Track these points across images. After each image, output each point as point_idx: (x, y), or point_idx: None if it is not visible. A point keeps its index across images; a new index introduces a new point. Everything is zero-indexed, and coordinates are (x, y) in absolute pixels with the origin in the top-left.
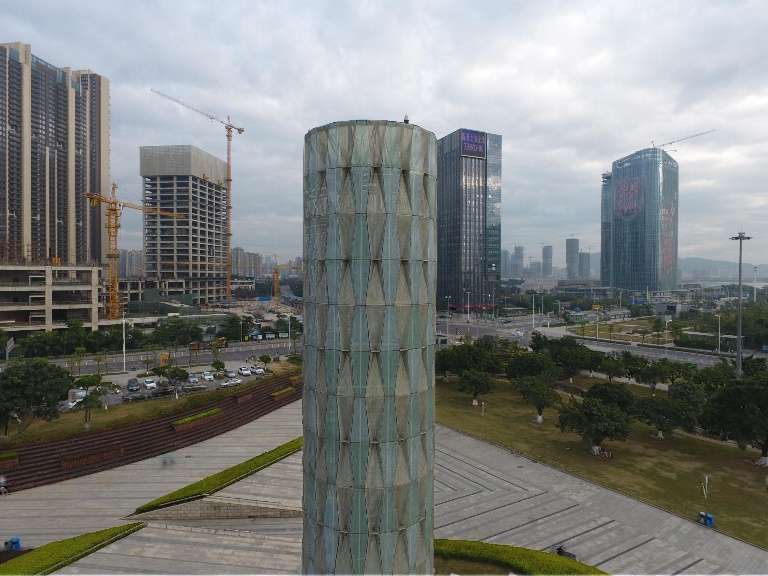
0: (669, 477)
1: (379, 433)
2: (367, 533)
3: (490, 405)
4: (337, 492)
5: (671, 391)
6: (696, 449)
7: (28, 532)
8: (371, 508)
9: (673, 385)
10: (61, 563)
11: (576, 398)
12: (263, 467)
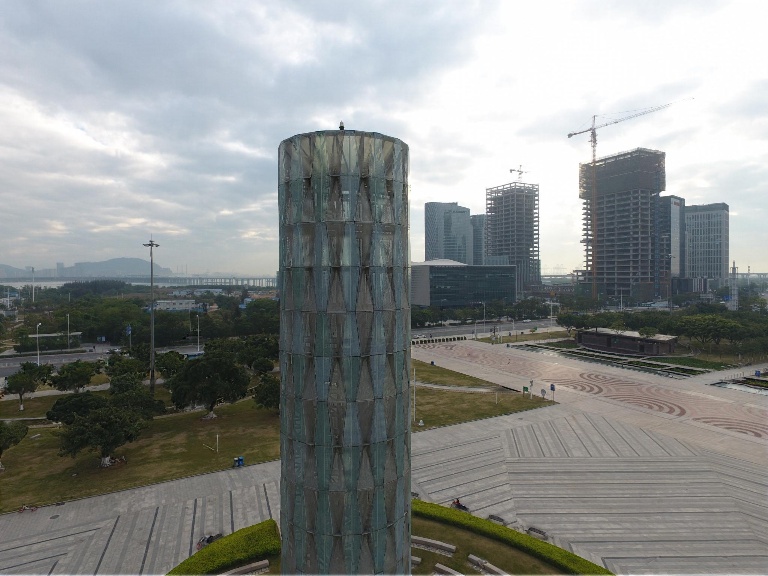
0: (182, 452)
1: None
2: None
3: None
4: None
5: (115, 387)
6: (166, 426)
7: None
8: None
9: (115, 381)
10: None
11: None
12: None
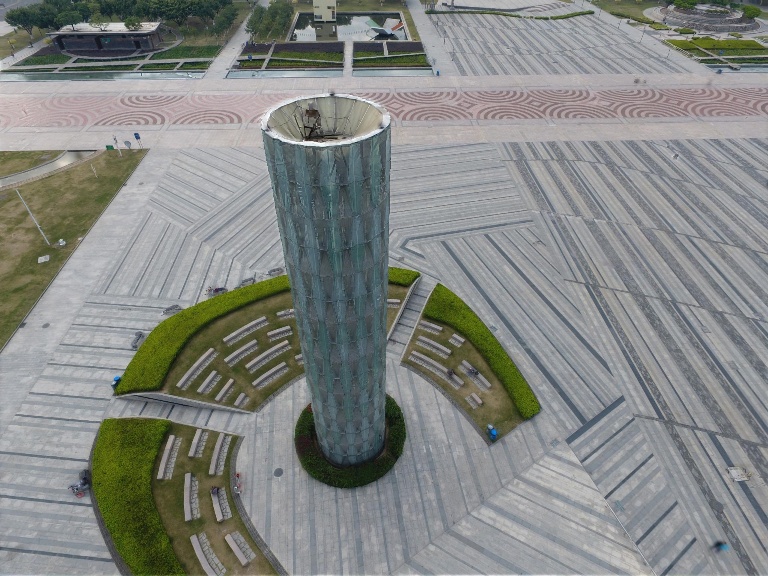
0: None
1: None
2: None
3: None
4: None
5: None
6: None
7: None
8: None
9: None
10: None
11: None
12: None
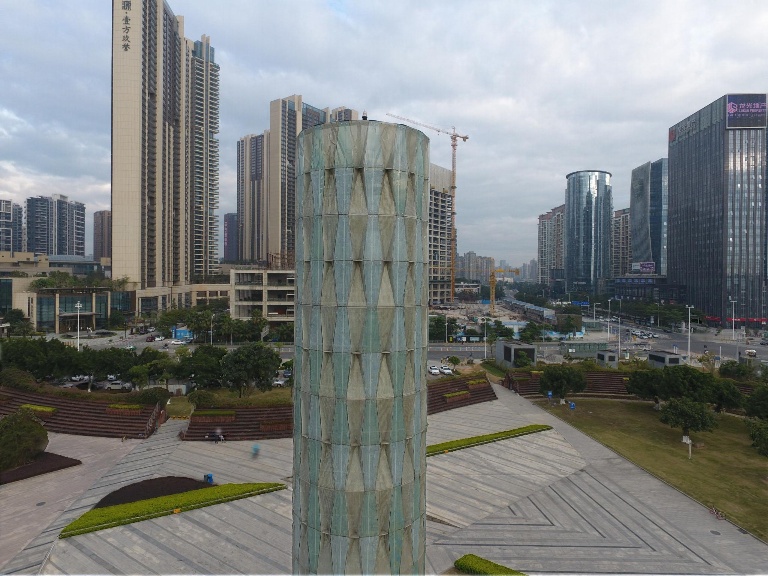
0: None
1: (331, 434)
2: (320, 530)
3: (708, 446)
4: (300, 483)
5: None
6: None
7: (222, 472)
8: (325, 507)
9: None
10: (220, 500)
11: None
12: None
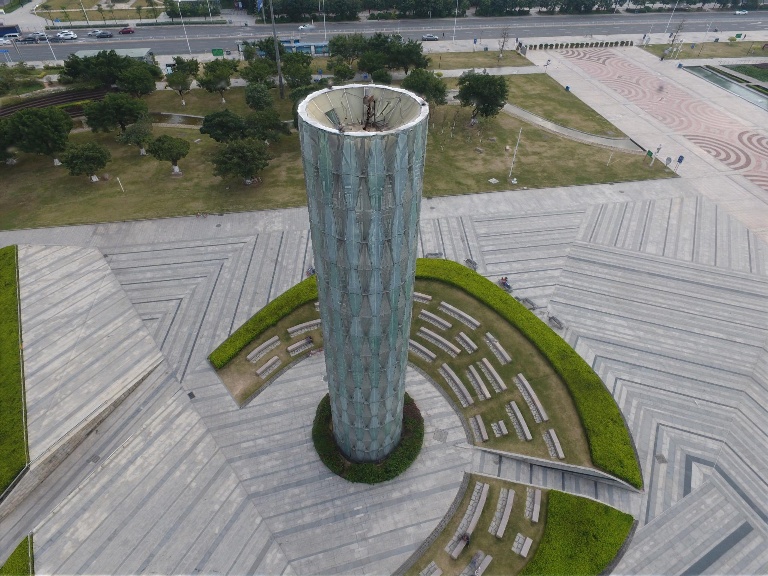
0: (302, 178)
1: None
2: None
3: (111, 174)
4: None
5: (249, 98)
6: (292, 145)
7: None
8: None
9: (249, 92)
10: None
11: (169, 127)
12: (23, 396)
